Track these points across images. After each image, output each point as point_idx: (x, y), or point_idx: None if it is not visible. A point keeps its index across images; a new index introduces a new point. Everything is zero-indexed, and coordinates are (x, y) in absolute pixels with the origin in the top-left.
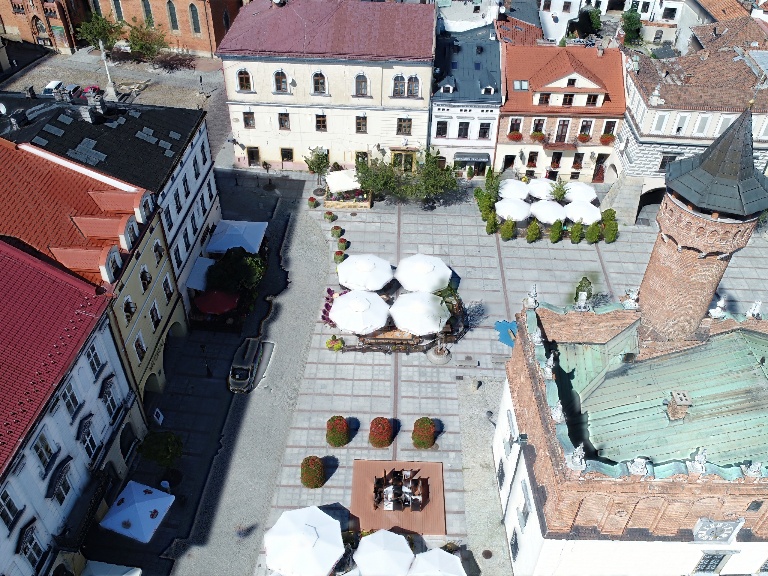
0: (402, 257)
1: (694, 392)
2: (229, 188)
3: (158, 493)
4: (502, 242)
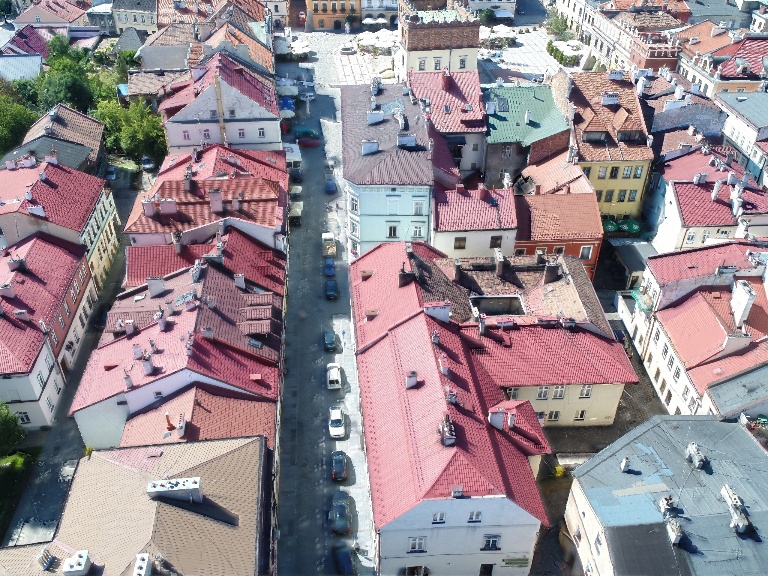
0: (523, 40)
1: None
2: None
3: None
4: (546, 51)
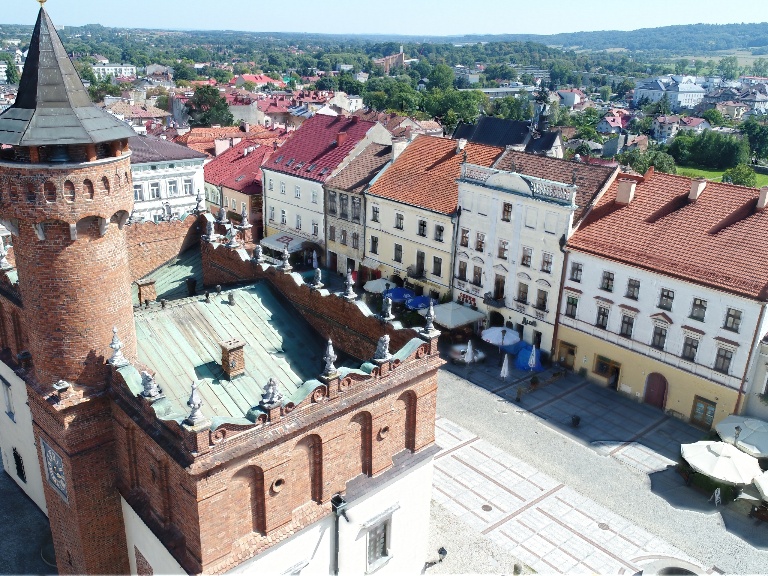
0: None
1: (194, 361)
2: None
3: None
4: None
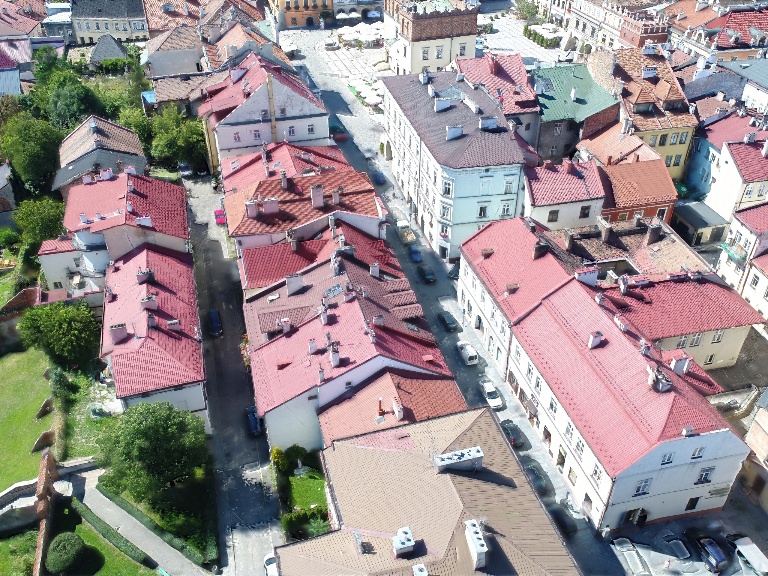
0: (496, 26)
1: None
2: (502, 4)
3: (379, 14)
4: None
